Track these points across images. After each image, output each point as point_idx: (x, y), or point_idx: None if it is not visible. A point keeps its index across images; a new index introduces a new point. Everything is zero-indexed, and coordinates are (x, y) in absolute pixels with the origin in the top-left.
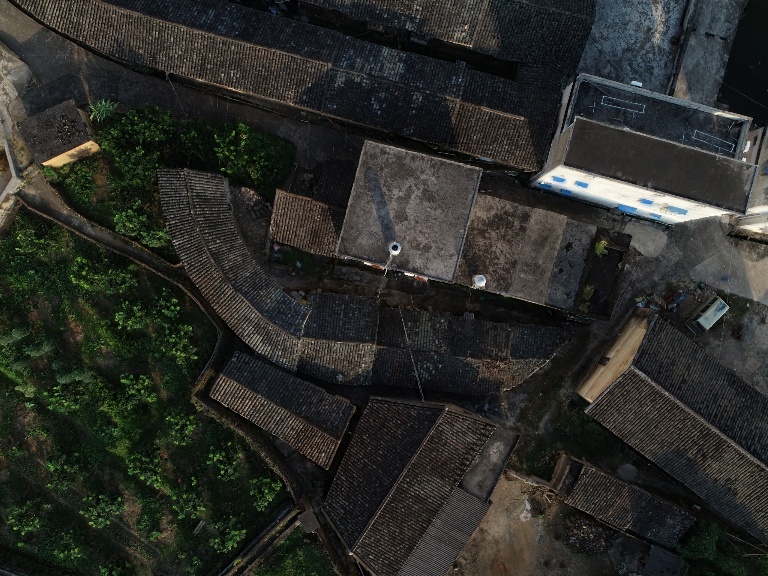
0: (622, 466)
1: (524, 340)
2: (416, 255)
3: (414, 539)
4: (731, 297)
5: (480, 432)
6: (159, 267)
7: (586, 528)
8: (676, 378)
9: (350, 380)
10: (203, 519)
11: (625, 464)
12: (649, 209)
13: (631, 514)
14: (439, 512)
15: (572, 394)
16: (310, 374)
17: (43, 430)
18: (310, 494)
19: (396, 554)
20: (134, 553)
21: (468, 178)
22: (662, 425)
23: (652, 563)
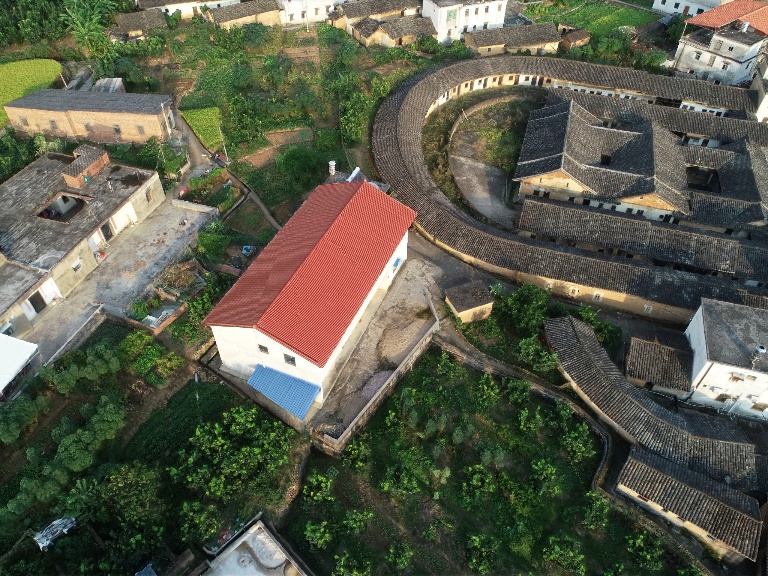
0: None
1: None
2: None
3: None
4: None
5: None
6: None
7: None
8: None
9: (738, 483)
10: None
11: None
12: None
13: None
14: None
15: None
16: None
17: (448, 522)
18: None
19: None
20: None
21: None
22: None
23: None
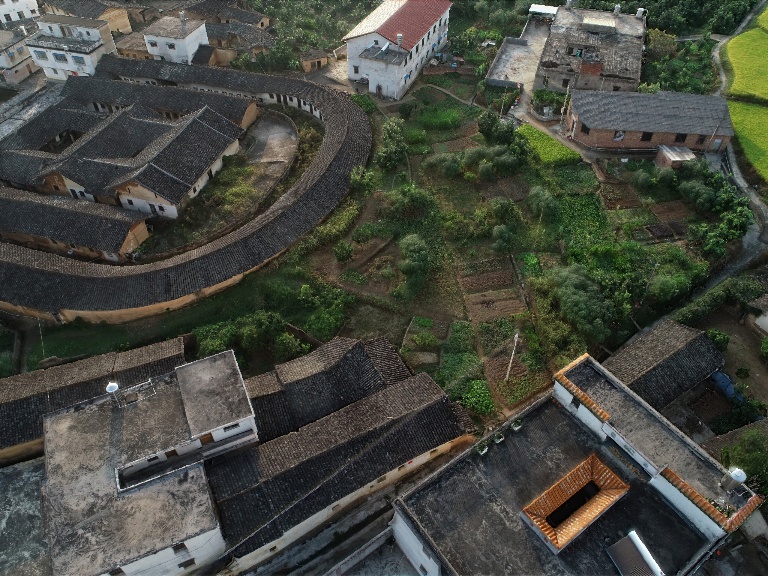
0: None
1: None
2: None
3: None
4: None
5: None
6: None
7: None
8: None
9: None
10: None
11: None
12: None
13: (128, 4)
14: None
15: None
16: None
17: None
18: None
19: None
20: None
21: (147, 31)
22: None
23: None
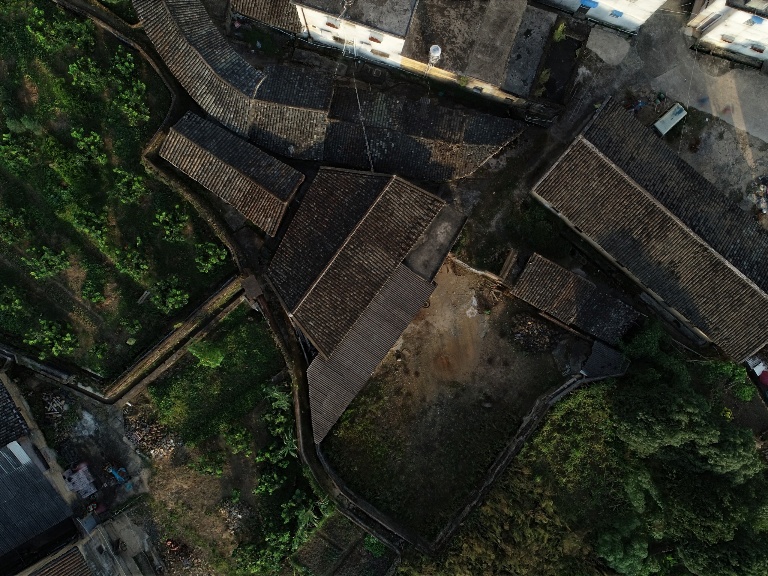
0: (571, 270)
1: (479, 128)
2: (370, 8)
3: (356, 311)
4: (690, 110)
5: (428, 207)
6: (117, 27)
7: (531, 324)
8: (625, 154)
9: (302, 153)
10: (148, 289)
11: (575, 268)
12: (610, 1)
13: (576, 307)
14: (383, 287)
15: (526, 195)
16: (262, 145)
17: None
18: (256, 271)
19: (337, 324)
20: (77, 319)
21: None
22: (608, 203)
23: (594, 358)
